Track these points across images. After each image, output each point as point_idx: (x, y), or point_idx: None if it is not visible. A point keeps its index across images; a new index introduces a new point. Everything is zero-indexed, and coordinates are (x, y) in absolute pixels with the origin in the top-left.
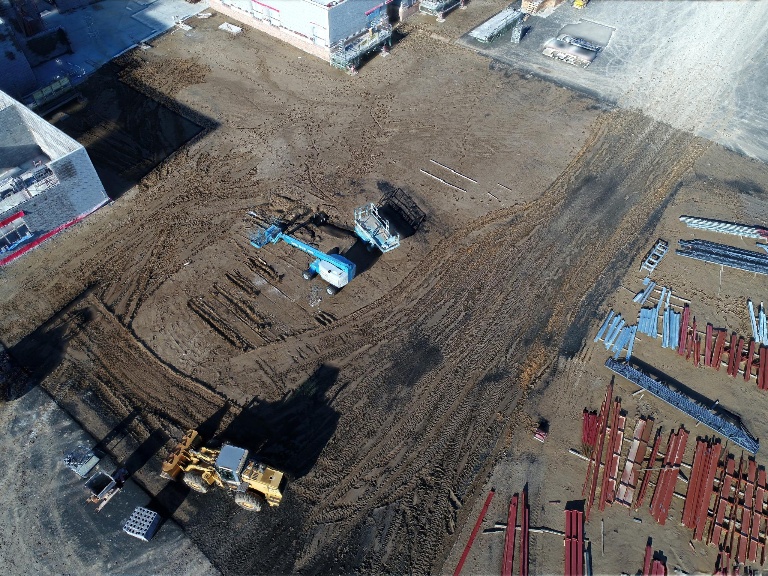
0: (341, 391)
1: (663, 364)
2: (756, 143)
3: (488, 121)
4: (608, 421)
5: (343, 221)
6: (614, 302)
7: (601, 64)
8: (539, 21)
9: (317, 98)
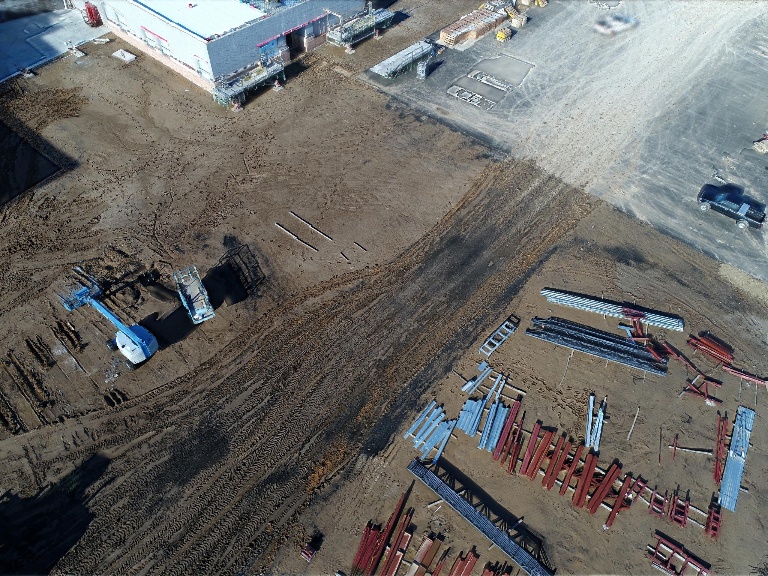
0: (103, 488)
1: (474, 469)
2: (651, 203)
3: (366, 168)
4: (391, 538)
5: (174, 281)
6: (440, 390)
7: (506, 106)
8: (455, 55)
9: (191, 137)
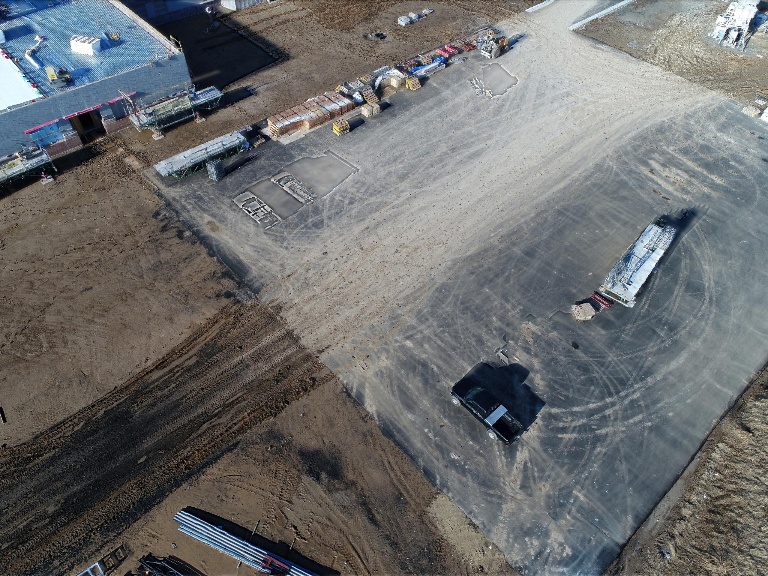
0: None
1: None
2: (393, 386)
3: (80, 299)
4: None
5: None
6: None
7: (292, 225)
8: (273, 149)
9: None
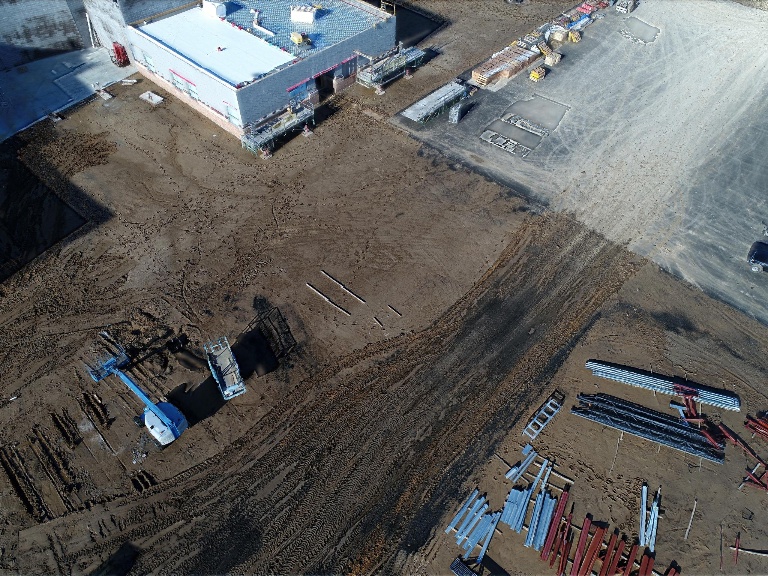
0: None
1: (521, 570)
2: (699, 263)
3: (399, 222)
4: None
5: (203, 348)
6: (482, 477)
7: (543, 153)
8: (487, 96)
9: (219, 187)
